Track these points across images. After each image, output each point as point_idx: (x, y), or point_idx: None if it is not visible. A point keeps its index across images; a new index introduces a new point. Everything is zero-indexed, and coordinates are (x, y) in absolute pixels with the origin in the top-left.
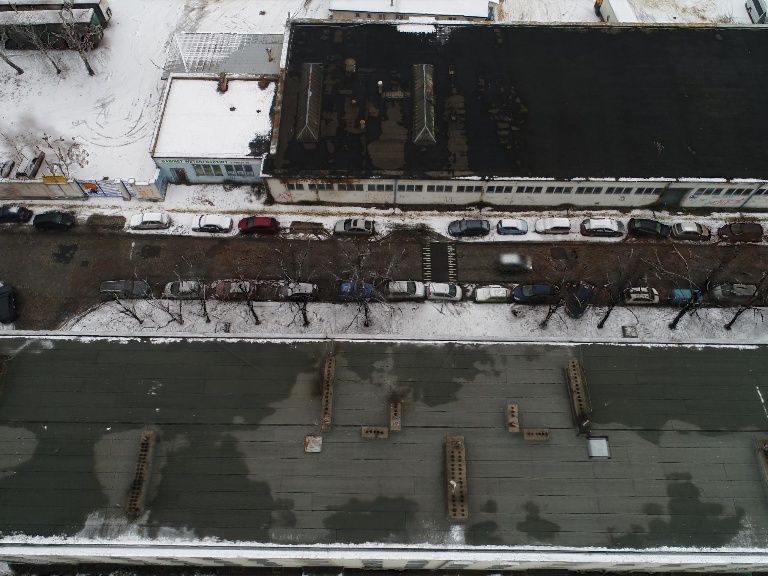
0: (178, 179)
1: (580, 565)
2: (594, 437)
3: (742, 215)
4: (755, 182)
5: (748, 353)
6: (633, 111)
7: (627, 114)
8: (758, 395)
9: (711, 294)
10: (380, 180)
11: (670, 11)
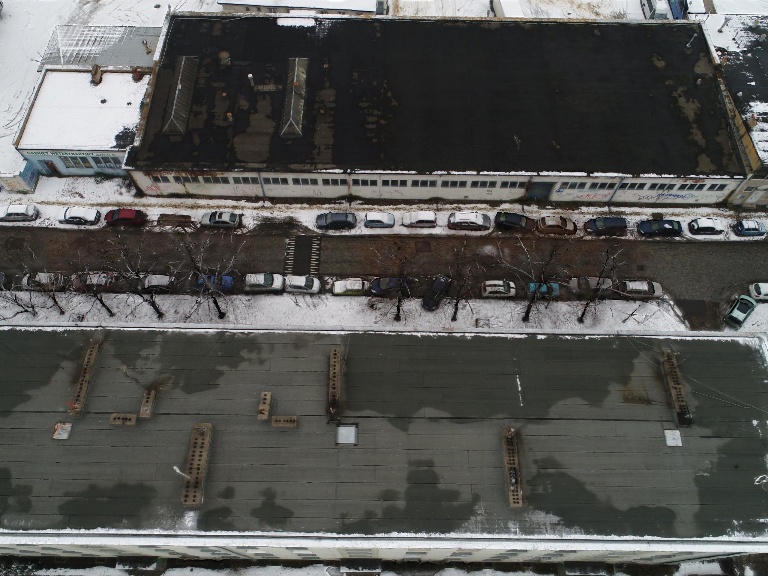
0: (50, 171)
1: (376, 554)
2: (344, 424)
3: (610, 209)
4: (615, 176)
5: (516, 342)
6: (503, 105)
7: (496, 108)
8: (516, 383)
9: (568, 287)
10: (243, 173)
11: (565, 7)
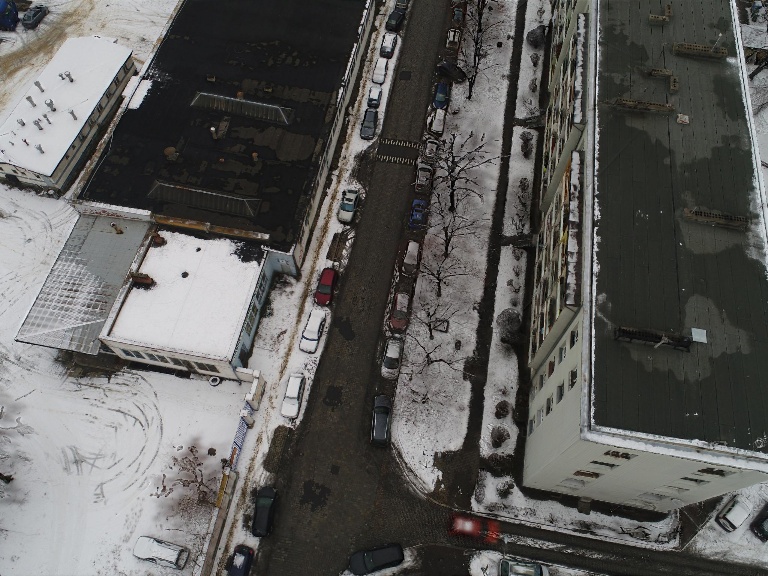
0: None
1: None
2: None
3: None
4: None
5: None
6: None
7: None
8: None
9: (458, 4)
10: None
11: None
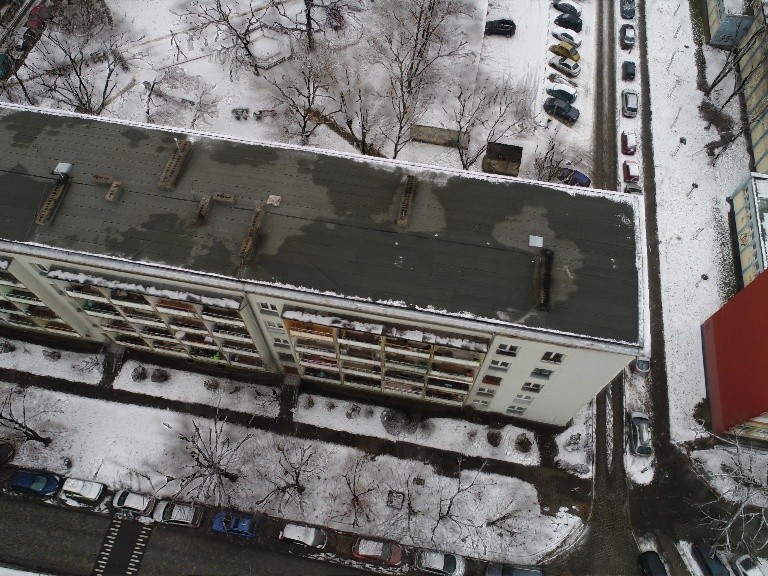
0: None
1: None
2: None
3: None
4: None
5: None
6: None
7: None
8: None
9: None
10: None
11: None
